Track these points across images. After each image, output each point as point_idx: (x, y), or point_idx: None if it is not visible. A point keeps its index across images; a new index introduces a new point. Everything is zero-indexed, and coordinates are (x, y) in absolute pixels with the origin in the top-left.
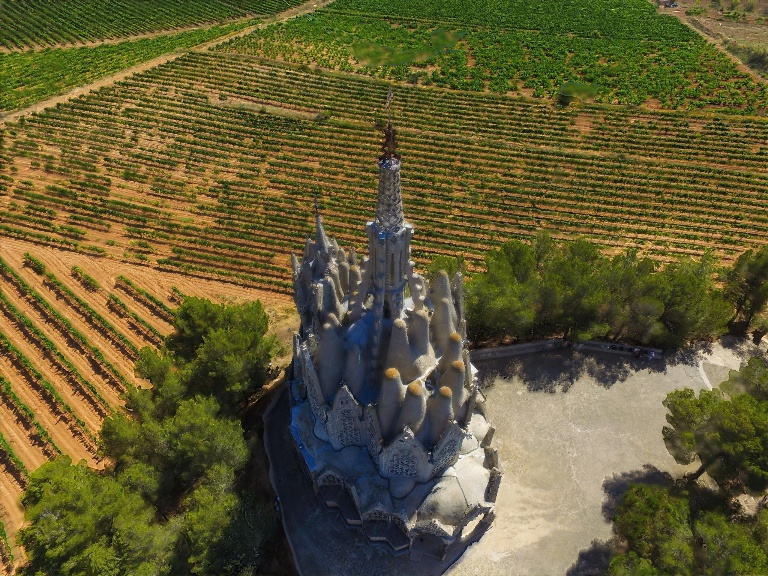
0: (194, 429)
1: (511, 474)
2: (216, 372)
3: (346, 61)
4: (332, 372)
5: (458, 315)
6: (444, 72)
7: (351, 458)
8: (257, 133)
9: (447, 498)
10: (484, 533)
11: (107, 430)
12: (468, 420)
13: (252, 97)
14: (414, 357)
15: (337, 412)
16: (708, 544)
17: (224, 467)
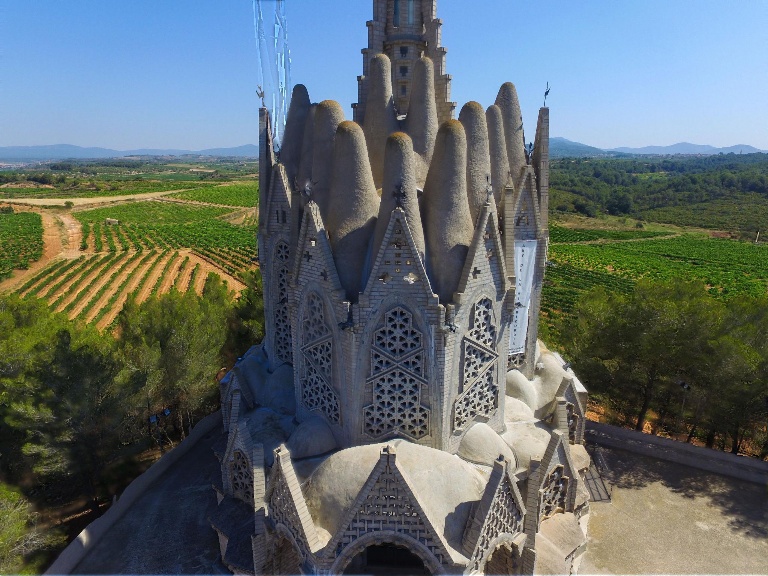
0: (172, 315)
1: None
2: (250, 308)
3: (602, 267)
4: (288, 172)
5: None
6: (727, 291)
7: (279, 383)
8: None
9: (352, 456)
10: None
11: (126, 314)
12: (460, 291)
13: None
14: None
15: (272, 244)
16: None
17: None
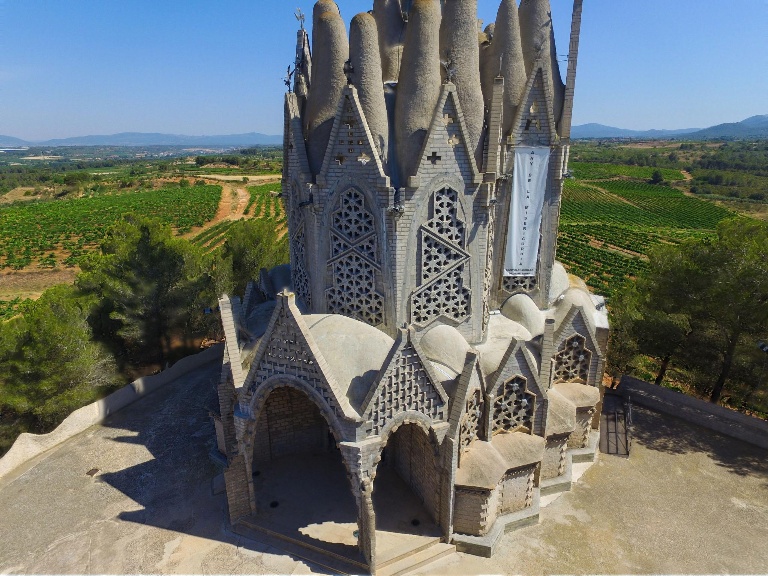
0: None
1: (536, 571)
2: None
3: None
4: None
5: (560, 101)
6: None
7: None
8: (612, 264)
9: None
10: (341, 575)
11: None
12: (414, 174)
13: (635, 252)
14: (394, 43)
15: None
16: None
17: (228, 263)
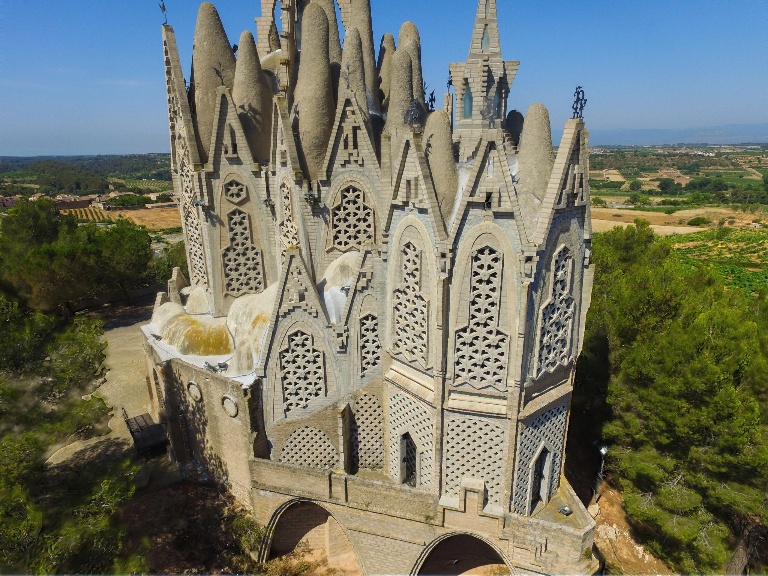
0: None
1: None
2: None
3: None
4: None
5: None
6: None
7: None
8: None
9: None
10: None
11: None
12: None
13: None
14: None
15: None
16: (43, 222)
17: None
